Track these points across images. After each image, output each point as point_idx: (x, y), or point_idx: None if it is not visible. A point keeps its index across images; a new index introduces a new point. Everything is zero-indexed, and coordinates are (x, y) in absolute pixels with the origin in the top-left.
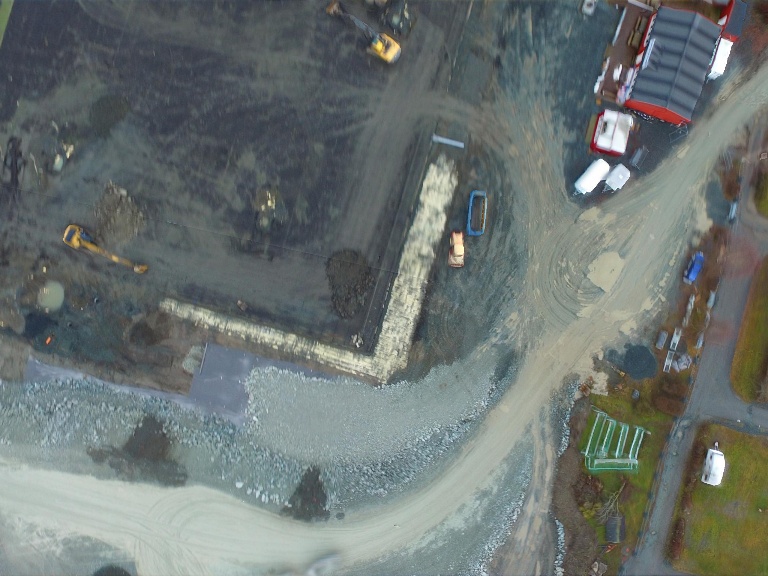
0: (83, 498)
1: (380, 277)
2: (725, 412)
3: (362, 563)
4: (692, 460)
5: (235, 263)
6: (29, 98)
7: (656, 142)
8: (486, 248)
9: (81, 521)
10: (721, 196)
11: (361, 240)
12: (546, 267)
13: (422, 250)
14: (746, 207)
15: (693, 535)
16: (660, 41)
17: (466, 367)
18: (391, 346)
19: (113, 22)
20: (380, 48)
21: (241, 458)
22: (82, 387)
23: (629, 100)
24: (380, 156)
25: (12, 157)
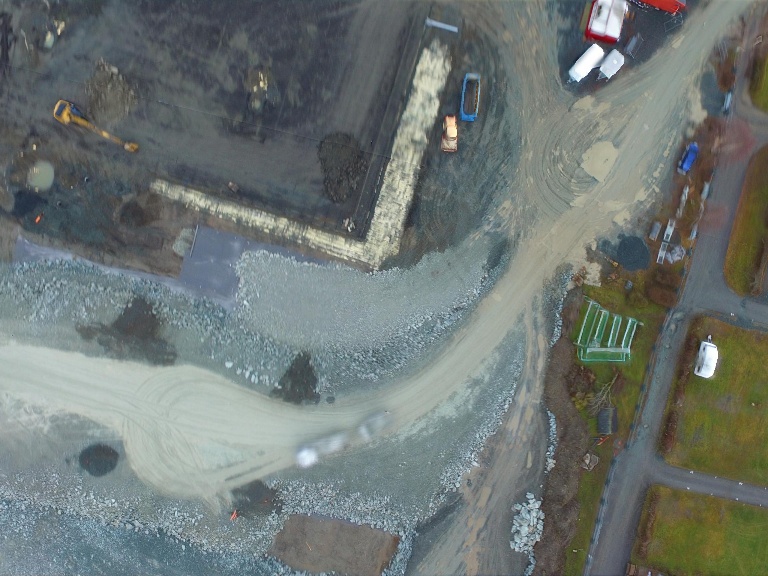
0: (71, 375)
1: (372, 161)
2: (718, 305)
3: (352, 448)
4: (685, 353)
5: (227, 144)
6: None
7: (651, 31)
8: (479, 134)
9: (69, 398)
10: (716, 87)
11: (354, 124)
12: (539, 155)
13: (415, 135)
14: (741, 99)
15: (686, 429)
16: None
17: (458, 255)
18: (383, 232)
19: None
20: None
21: (231, 341)
22: (71, 267)
23: None
24: (373, 39)
25: (3, 33)
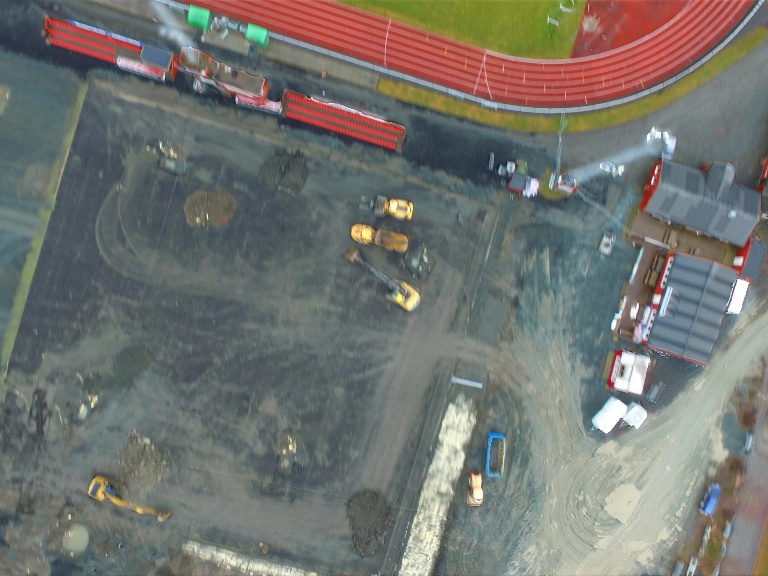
0: None
1: (400, 516)
2: None
3: None
4: None
5: (257, 506)
6: (54, 350)
7: (672, 376)
8: (504, 485)
9: None
10: (737, 427)
11: (381, 480)
12: (563, 501)
13: (441, 488)
14: (762, 437)
15: None
16: (677, 288)
17: None
18: None
19: (136, 274)
20: (400, 300)
21: None
22: None
23: (646, 342)
24: (400, 398)
25: (37, 408)
